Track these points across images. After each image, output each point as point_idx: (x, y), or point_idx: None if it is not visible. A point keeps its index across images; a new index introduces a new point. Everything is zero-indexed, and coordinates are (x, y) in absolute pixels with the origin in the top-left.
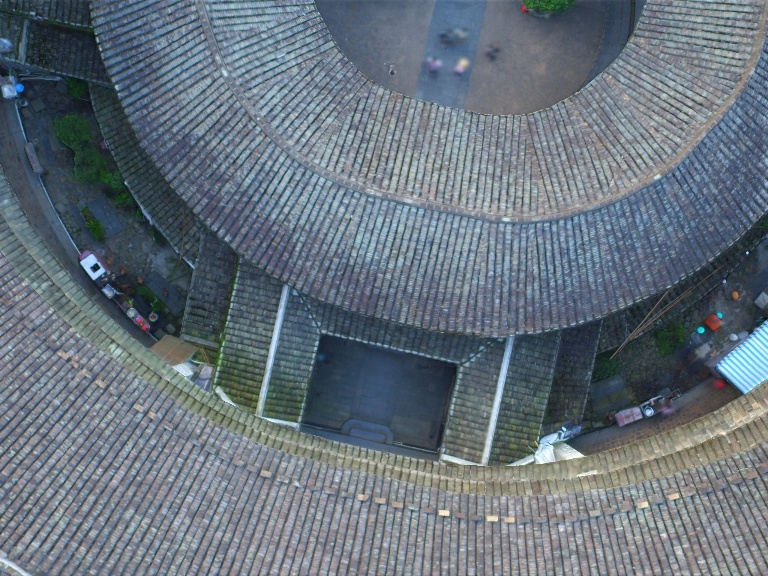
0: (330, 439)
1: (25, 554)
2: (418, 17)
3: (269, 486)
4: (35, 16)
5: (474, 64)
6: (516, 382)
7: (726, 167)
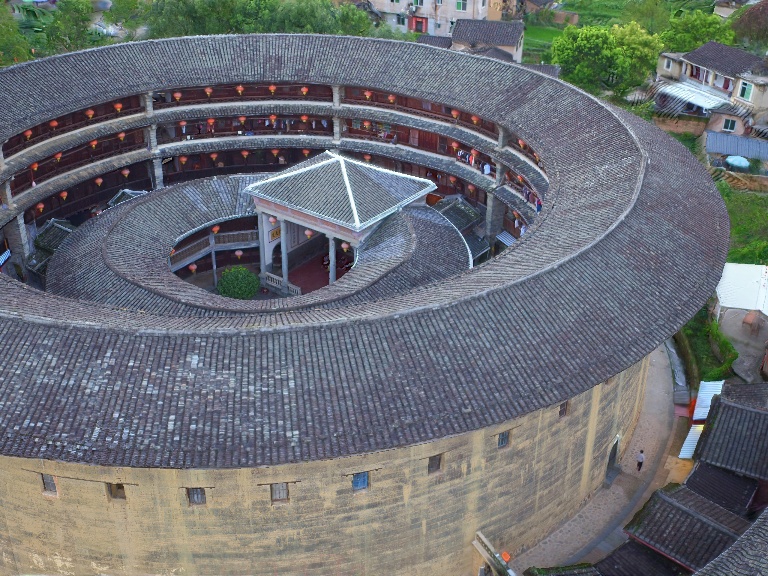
0: None
1: None
2: None
3: None
4: None
5: None
6: None
7: None
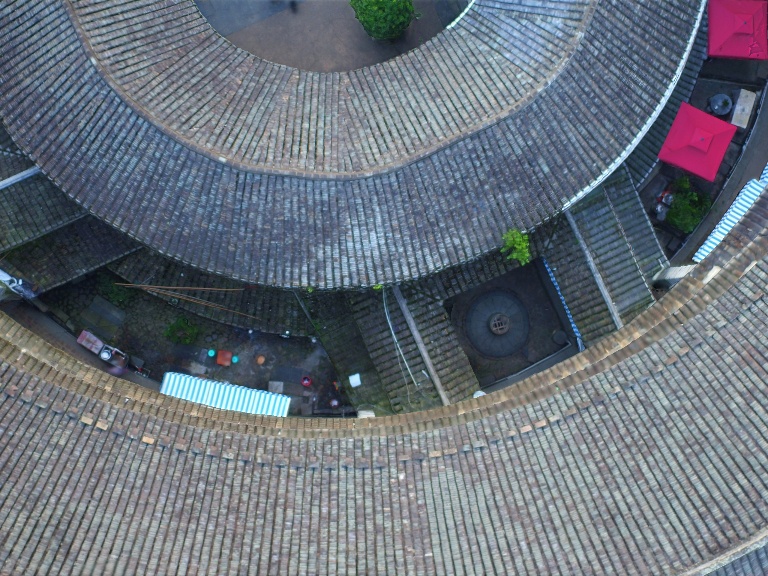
0: None
1: None
2: None
3: None
4: None
5: (291, 8)
6: (11, 200)
7: (285, 218)
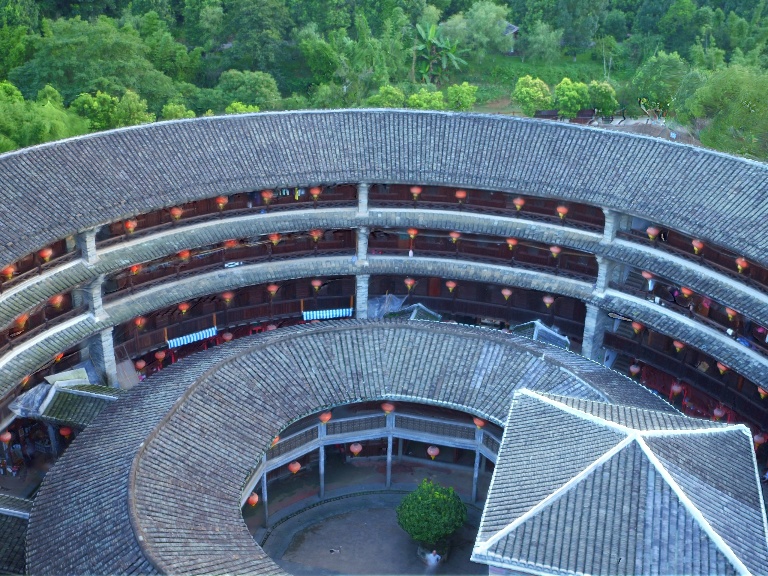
0: (21, 495)
1: (21, 159)
2: (384, 571)
3: (2, 243)
4: None
5: None
6: None
7: None
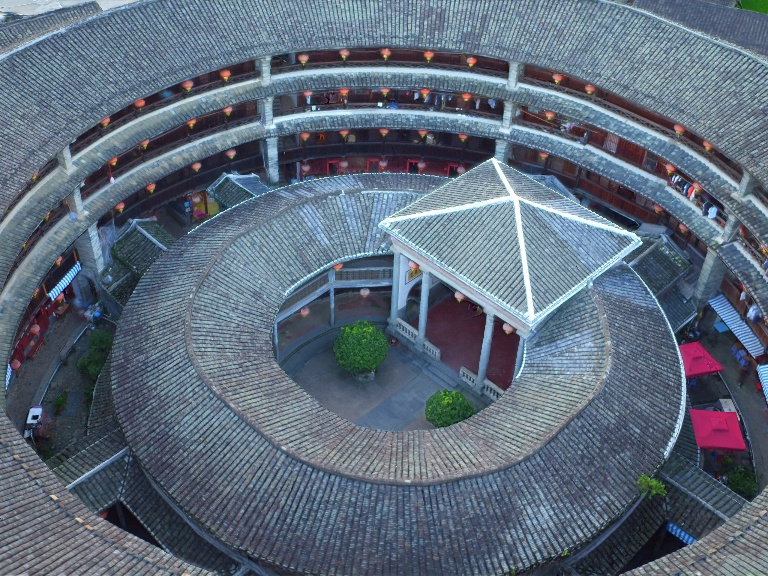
0: None
1: None
2: (360, 407)
3: None
4: (135, 269)
5: None
6: None
7: (470, 516)
